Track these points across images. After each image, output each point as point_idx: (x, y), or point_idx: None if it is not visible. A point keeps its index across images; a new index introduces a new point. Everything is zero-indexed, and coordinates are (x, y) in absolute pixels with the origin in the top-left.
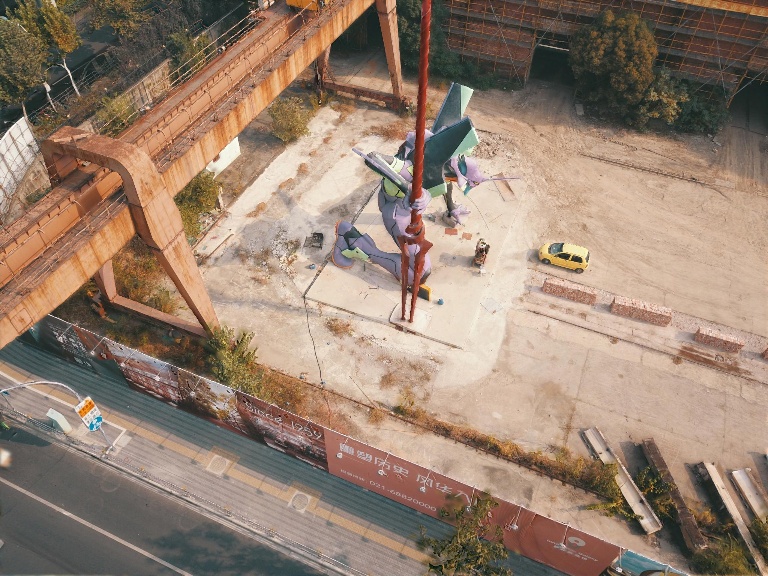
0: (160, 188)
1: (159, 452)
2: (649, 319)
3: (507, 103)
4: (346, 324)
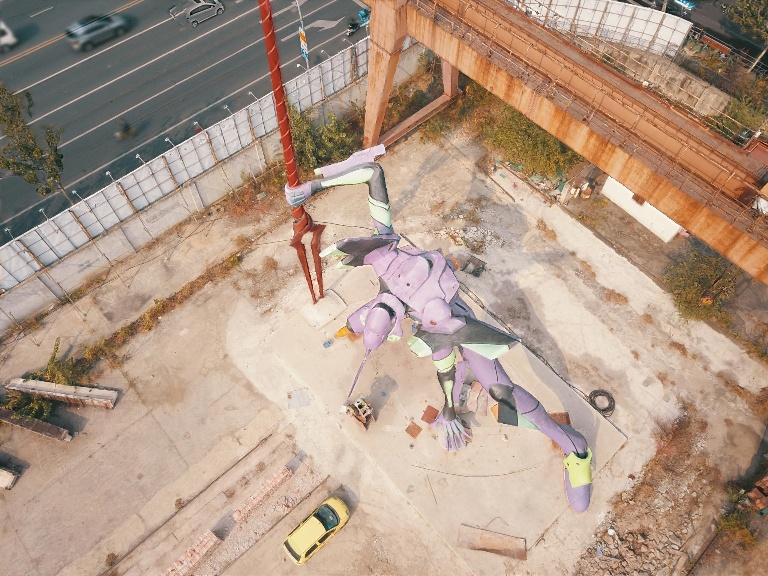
0: (392, 4)
1: None
2: None
3: None
4: None
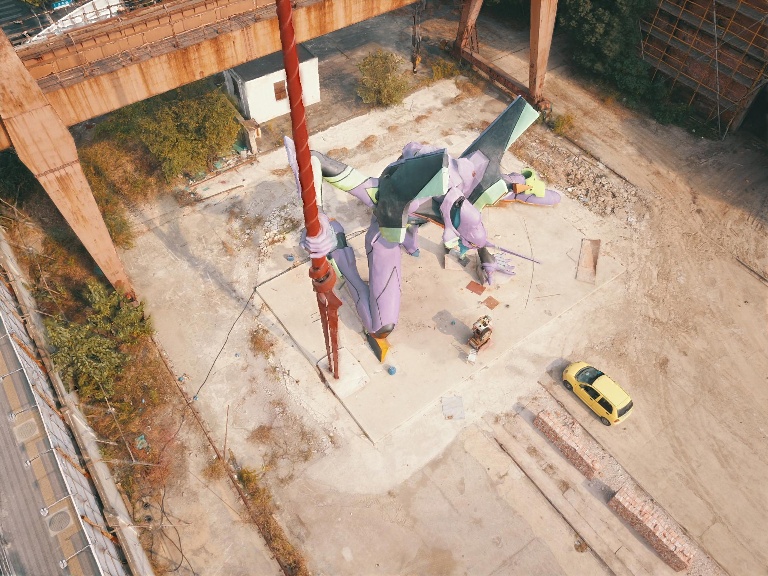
0: (39, 103)
1: None
2: (656, 546)
3: (682, 151)
4: (272, 342)
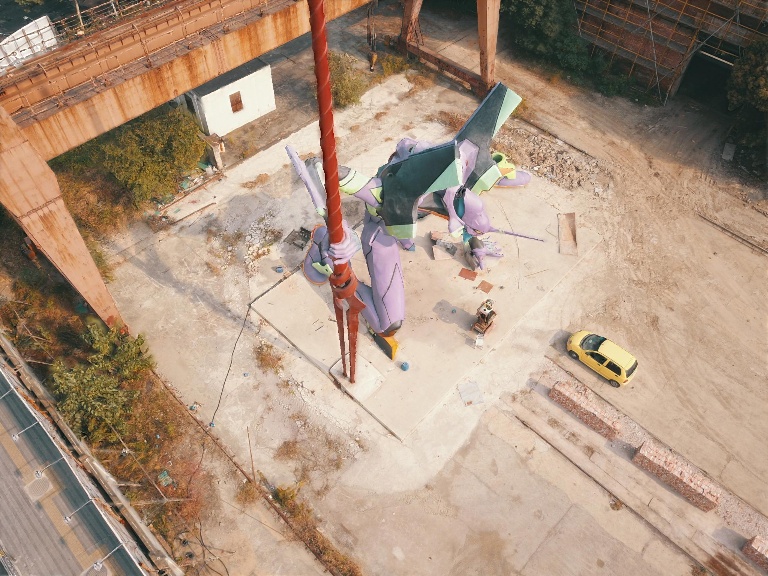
0: (17, 140)
1: None
2: (684, 492)
3: (630, 120)
4: (278, 356)
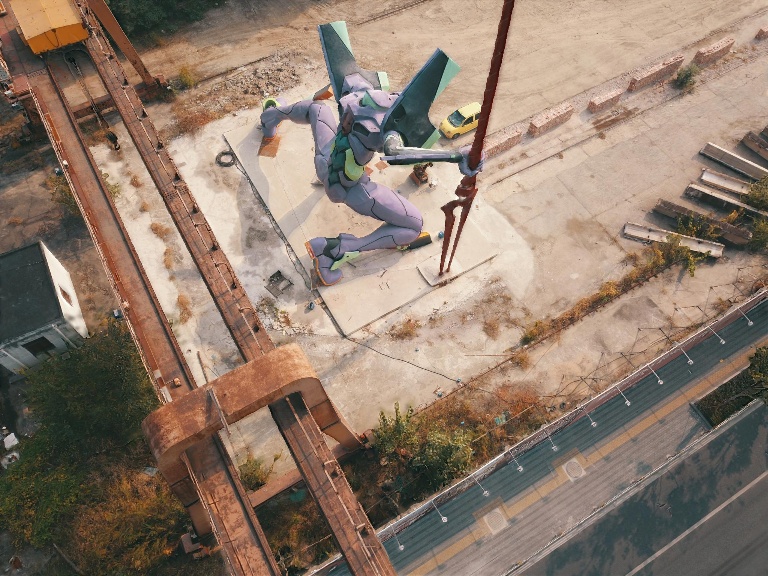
0: None
1: (446, 571)
2: (559, 122)
3: (238, 18)
4: (406, 322)
